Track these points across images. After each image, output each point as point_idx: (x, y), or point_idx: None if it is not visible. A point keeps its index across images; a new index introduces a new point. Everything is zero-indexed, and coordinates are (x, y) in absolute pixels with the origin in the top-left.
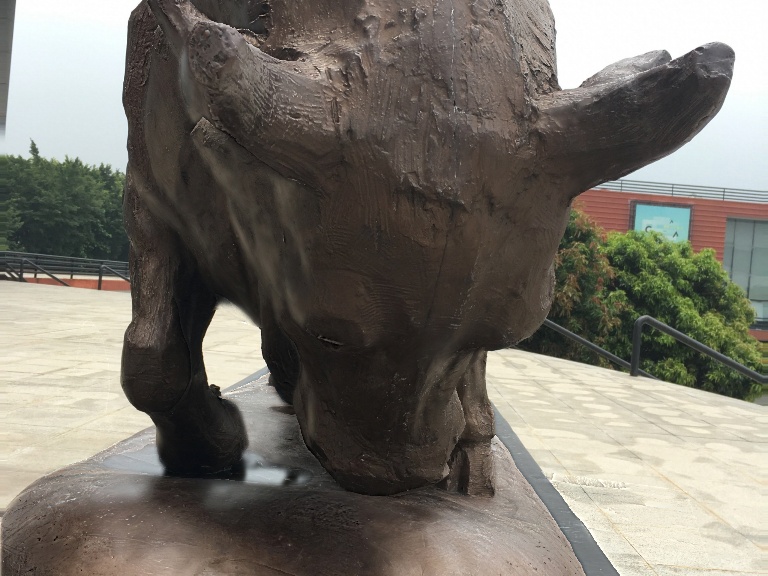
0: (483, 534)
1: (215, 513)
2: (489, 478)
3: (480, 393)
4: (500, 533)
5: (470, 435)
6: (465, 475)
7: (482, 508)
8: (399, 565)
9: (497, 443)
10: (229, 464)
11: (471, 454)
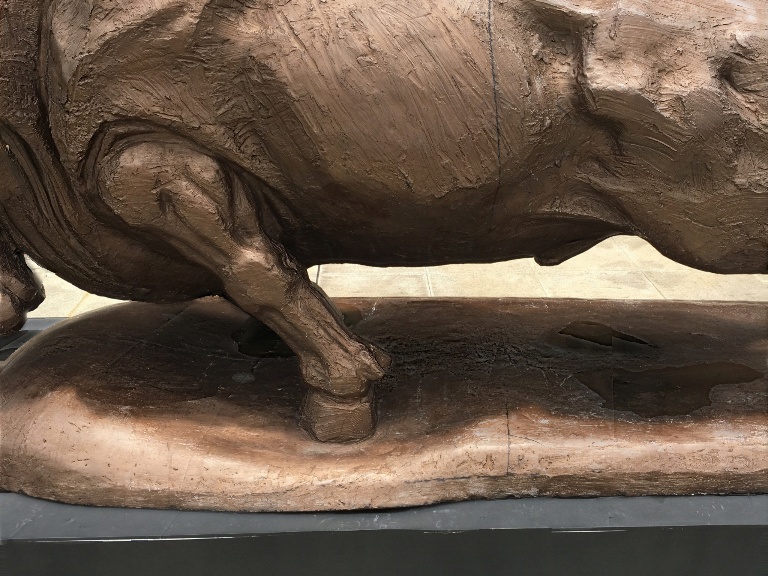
0: (51, 394)
1: None
2: (315, 424)
3: (311, 349)
4: (65, 402)
5: None
6: None
7: (254, 430)
8: None
9: (530, 439)
10: None
11: (309, 396)
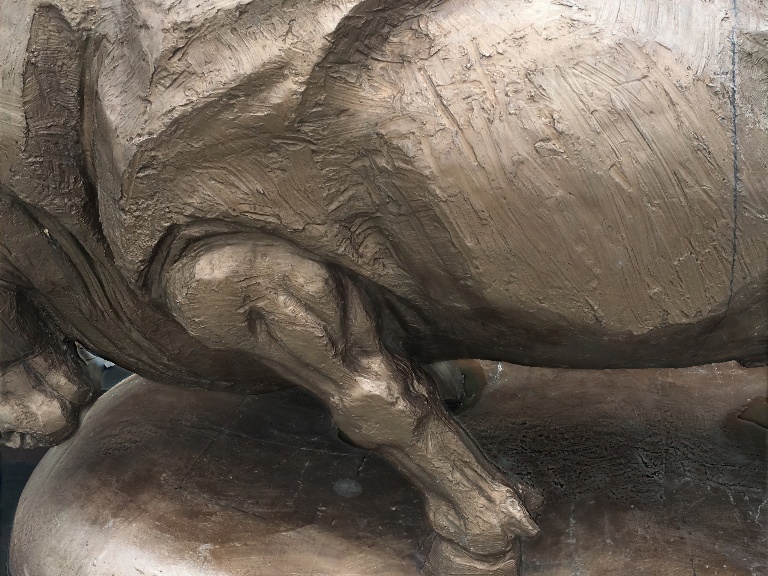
0: (114, 522)
1: None
2: None
3: (442, 494)
4: (131, 537)
5: None
6: None
7: None
8: (66, 483)
9: None
10: None
11: (436, 543)
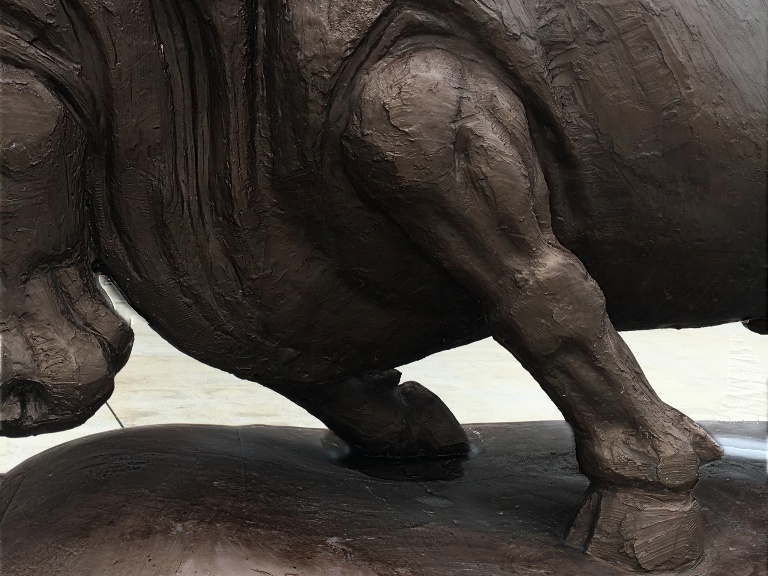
0: (183, 525)
1: (86, 445)
2: (633, 542)
3: (622, 414)
4: (222, 536)
5: (598, 471)
6: (593, 526)
7: (535, 566)
8: (53, 513)
9: None
10: (394, 452)
11: (607, 499)
